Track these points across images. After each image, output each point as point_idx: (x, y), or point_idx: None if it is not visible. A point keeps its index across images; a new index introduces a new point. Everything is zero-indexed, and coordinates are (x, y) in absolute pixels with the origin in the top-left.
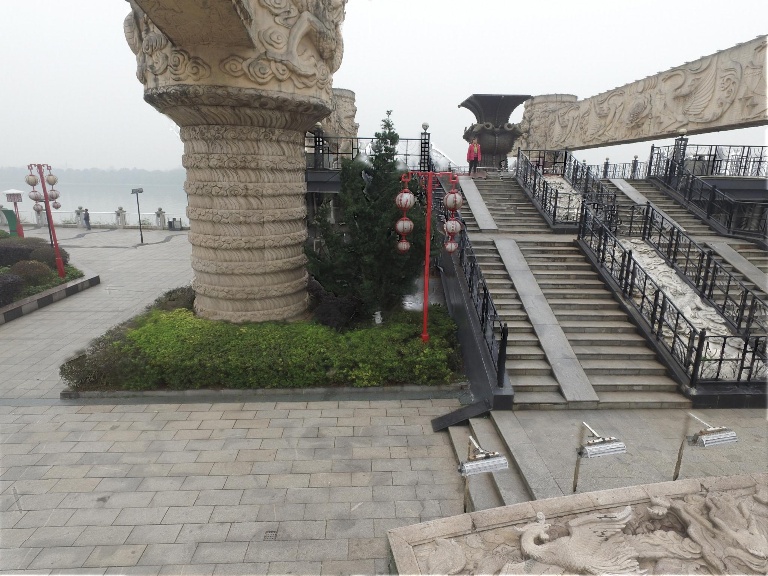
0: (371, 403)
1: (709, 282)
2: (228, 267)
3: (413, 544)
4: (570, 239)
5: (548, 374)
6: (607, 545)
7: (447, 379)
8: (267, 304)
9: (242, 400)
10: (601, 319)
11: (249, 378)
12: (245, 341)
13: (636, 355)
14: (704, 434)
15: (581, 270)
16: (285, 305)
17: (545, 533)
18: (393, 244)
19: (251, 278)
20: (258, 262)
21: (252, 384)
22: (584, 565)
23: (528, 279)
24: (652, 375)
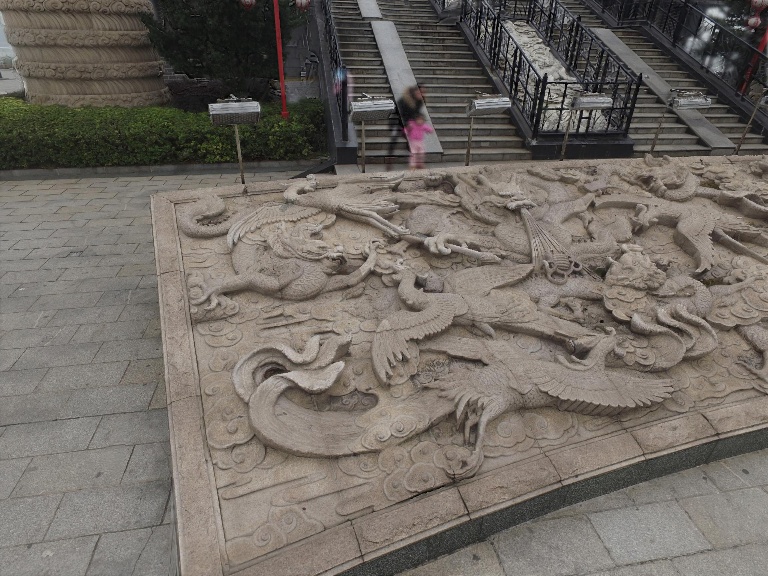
0: (222, 175)
1: (575, 52)
2: (48, 36)
3: (176, 202)
4: (453, 22)
5: (400, 135)
6: (370, 195)
7: (305, 152)
8: (109, 87)
9: (79, 177)
10: (466, 91)
11: (84, 153)
12: (77, 117)
13: (491, 119)
14: (478, 99)
15: (458, 51)
16: (133, 91)
17: (311, 187)
18: (242, 5)
19: (81, 52)
20: (85, 30)
21: (89, 161)
22: (339, 204)
23: (398, 55)
24: (502, 135)
